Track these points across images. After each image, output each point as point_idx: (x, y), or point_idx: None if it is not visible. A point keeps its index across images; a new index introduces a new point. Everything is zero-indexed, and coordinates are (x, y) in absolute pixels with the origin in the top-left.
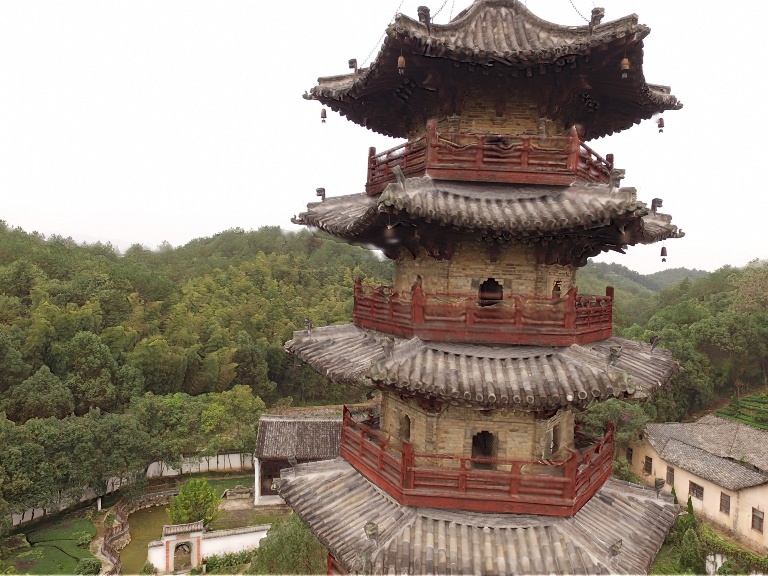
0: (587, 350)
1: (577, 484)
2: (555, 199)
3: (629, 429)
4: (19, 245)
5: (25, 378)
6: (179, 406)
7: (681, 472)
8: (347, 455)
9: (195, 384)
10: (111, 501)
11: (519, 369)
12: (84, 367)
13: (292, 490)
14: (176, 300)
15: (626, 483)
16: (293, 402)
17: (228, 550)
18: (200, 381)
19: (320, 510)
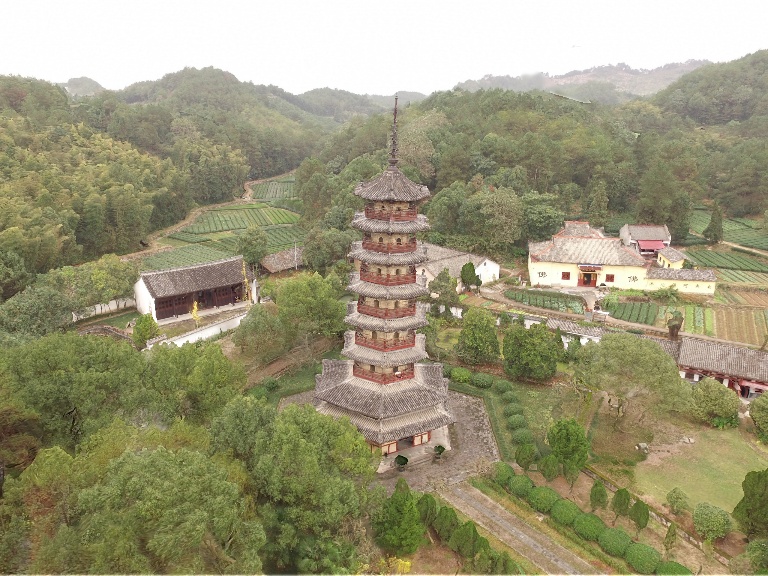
0: None
1: None
2: (413, 222)
3: None
4: None
5: None
6: (73, 275)
7: None
8: (364, 279)
9: (40, 257)
10: None
11: None
12: None
13: (353, 289)
14: None
15: None
16: (89, 258)
17: None
18: (45, 254)
19: (364, 291)
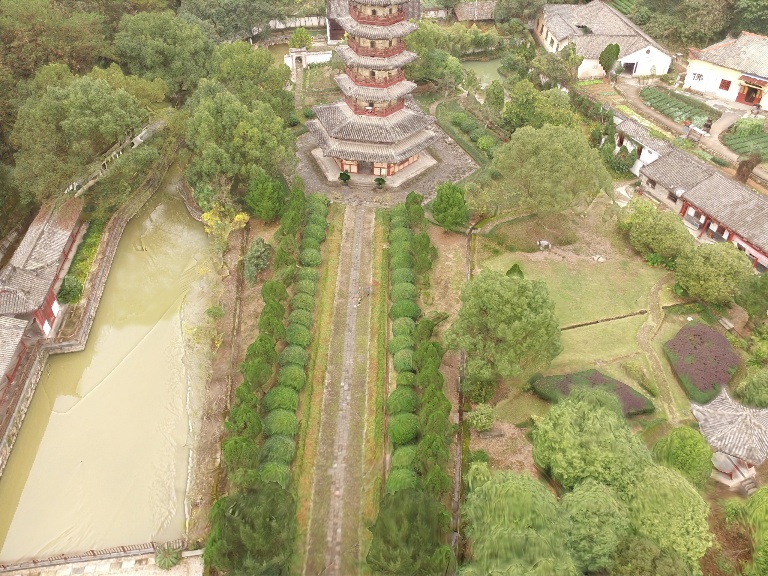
0: None
1: None
2: None
3: (533, 8)
4: None
5: None
6: None
7: (550, 33)
8: (350, 14)
9: None
10: (255, 40)
11: None
12: None
13: (340, 21)
14: None
15: None
16: None
17: (318, 61)
18: None
19: (345, 25)
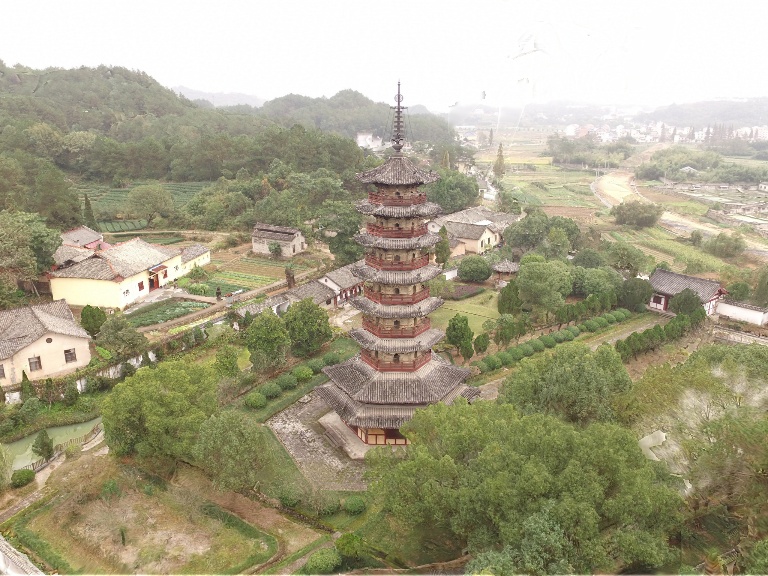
0: None
1: None
2: None
3: None
4: None
5: None
6: None
7: None
8: None
9: None
10: None
11: None
12: None
13: None
14: None
15: None
16: None
17: None
18: None
19: None
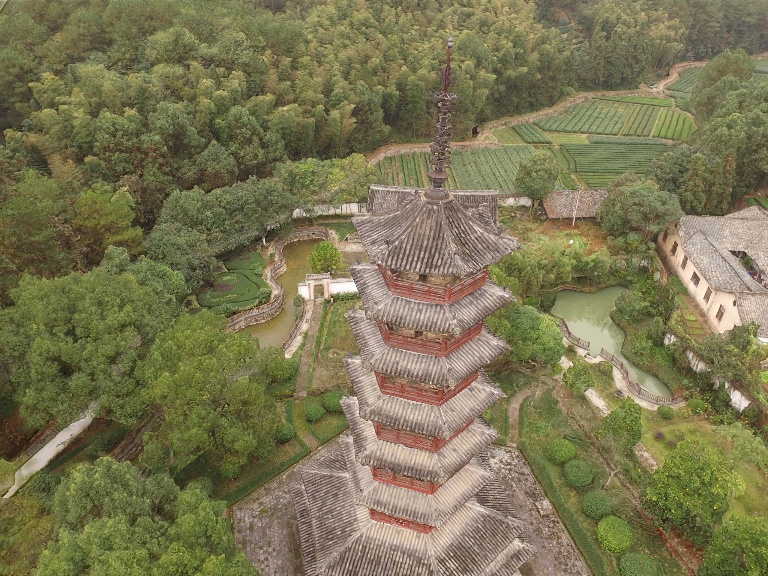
0: (446, 362)
1: (445, 395)
2: (441, 306)
3: (663, 222)
4: (169, 3)
5: (202, 148)
6: (311, 171)
7: (691, 263)
8: None
9: (323, 137)
10: (271, 236)
11: (422, 362)
12: (240, 137)
13: (349, 366)
14: (303, 51)
15: (483, 383)
16: (406, 139)
17: (346, 290)
18: (327, 135)
19: (358, 379)
